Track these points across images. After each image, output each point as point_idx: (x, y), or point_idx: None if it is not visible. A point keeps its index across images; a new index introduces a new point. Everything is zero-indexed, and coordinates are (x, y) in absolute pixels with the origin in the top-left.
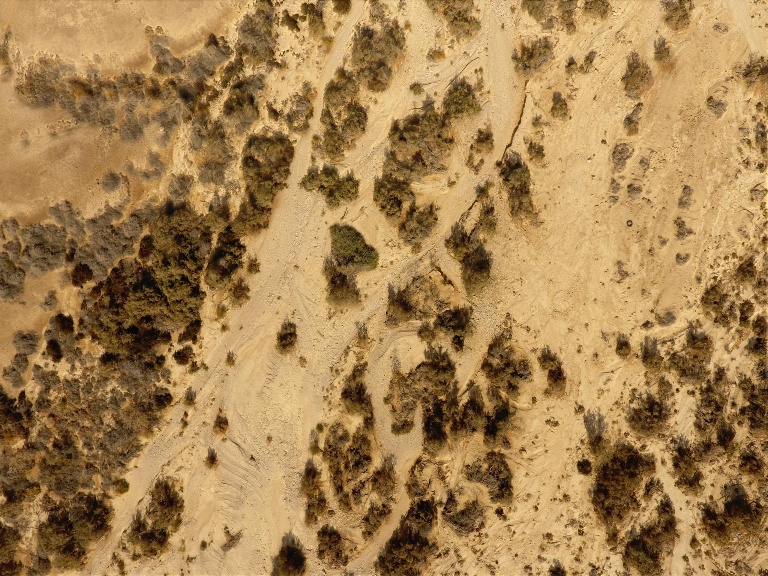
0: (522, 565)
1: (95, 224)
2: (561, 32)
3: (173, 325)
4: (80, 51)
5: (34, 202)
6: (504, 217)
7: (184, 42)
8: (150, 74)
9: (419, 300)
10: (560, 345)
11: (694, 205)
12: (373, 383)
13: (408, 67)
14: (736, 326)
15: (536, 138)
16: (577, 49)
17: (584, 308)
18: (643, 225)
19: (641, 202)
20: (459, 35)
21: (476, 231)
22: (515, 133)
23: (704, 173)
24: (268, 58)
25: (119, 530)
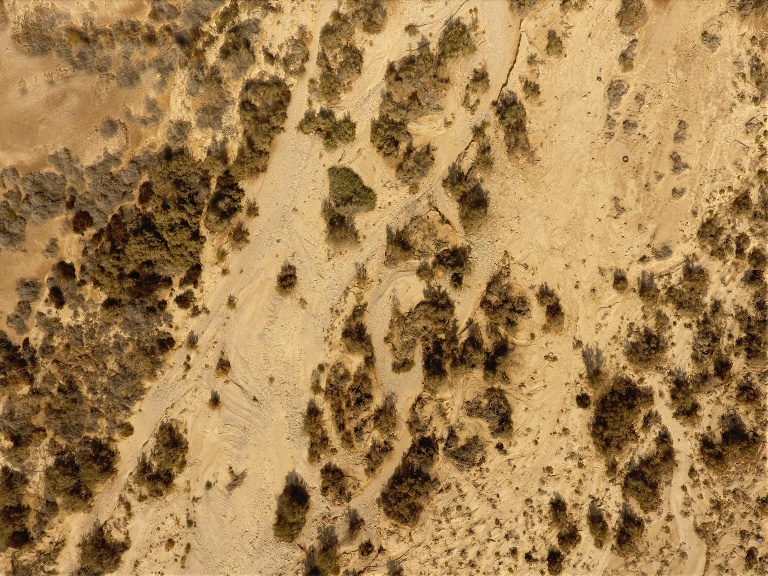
0: (523, 498)
1: (94, 171)
2: None
3: (174, 270)
4: None
5: (33, 150)
6: (501, 156)
7: None
8: (146, 21)
9: (417, 240)
10: (558, 281)
11: (689, 140)
12: (373, 323)
13: (403, 9)
14: (732, 259)
15: (531, 77)
16: None
17: (581, 244)
18: (639, 161)
19: (637, 138)
20: None
21: (473, 170)
22: (510, 72)
23: (699, 108)
24: (263, 2)
25: (125, 473)
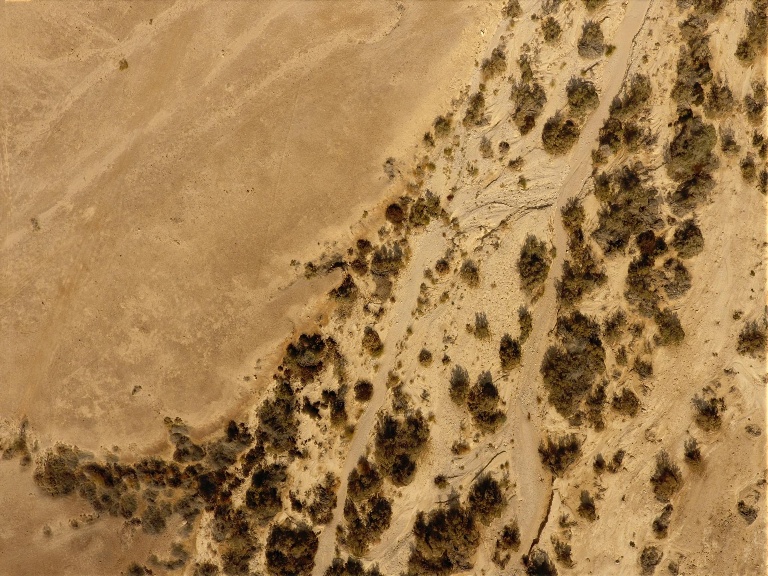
0: None
1: None
2: (589, 429)
3: None
4: (99, 443)
5: None
6: None
7: (204, 430)
8: (170, 461)
9: None
10: None
11: None
12: None
13: (433, 460)
14: None
15: (563, 538)
16: (605, 446)
17: None
18: None
19: None
20: (485, 430)
21: None
22: (542, 531)
23: None
24: (290, 448)
25: None
